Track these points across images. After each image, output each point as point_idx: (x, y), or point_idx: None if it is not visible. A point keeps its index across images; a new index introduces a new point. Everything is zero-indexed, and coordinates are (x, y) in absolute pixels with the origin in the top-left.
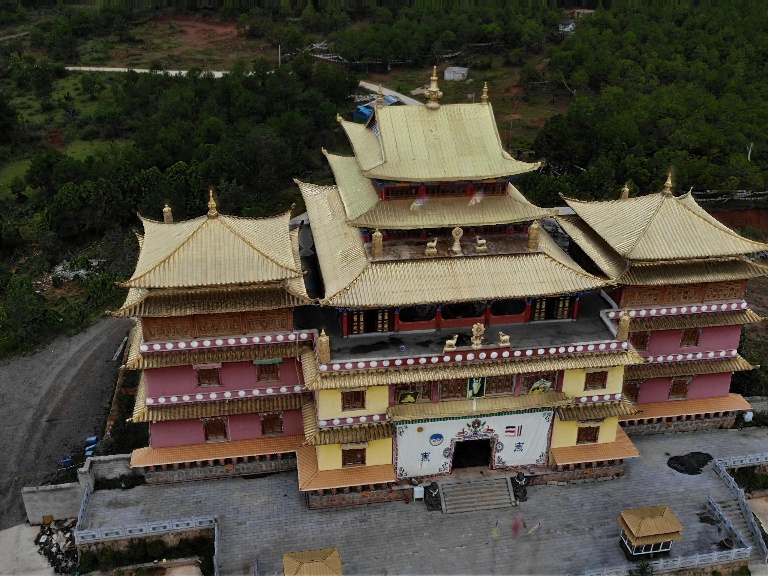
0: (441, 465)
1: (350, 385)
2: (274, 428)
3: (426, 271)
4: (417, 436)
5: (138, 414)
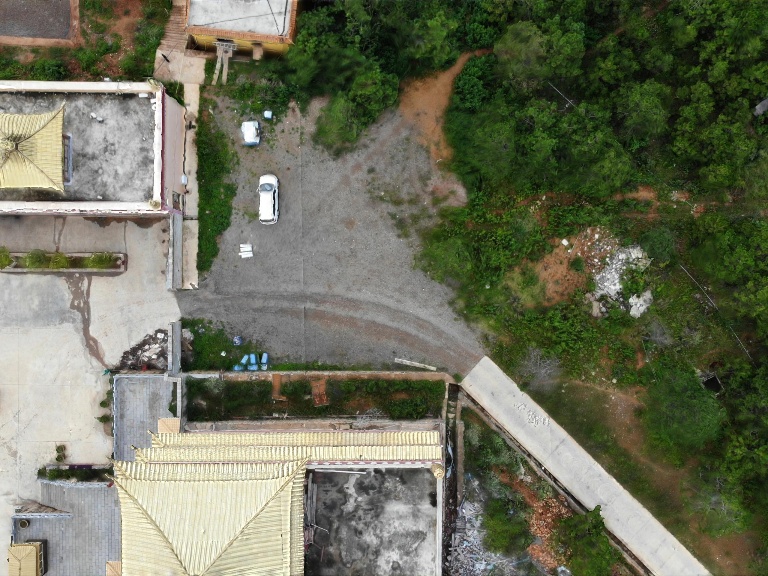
0: None
1: None
2: None
3: None
4: None
5: (157, 439)
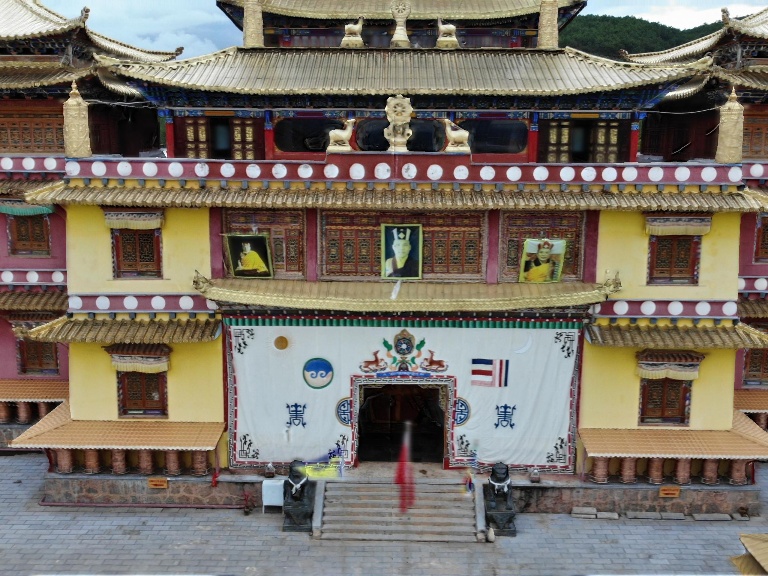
0: (333, 442)
1: (114, 198)
2: (44, 361)
3: (333, 61)
4: (275, 358)
5: None
